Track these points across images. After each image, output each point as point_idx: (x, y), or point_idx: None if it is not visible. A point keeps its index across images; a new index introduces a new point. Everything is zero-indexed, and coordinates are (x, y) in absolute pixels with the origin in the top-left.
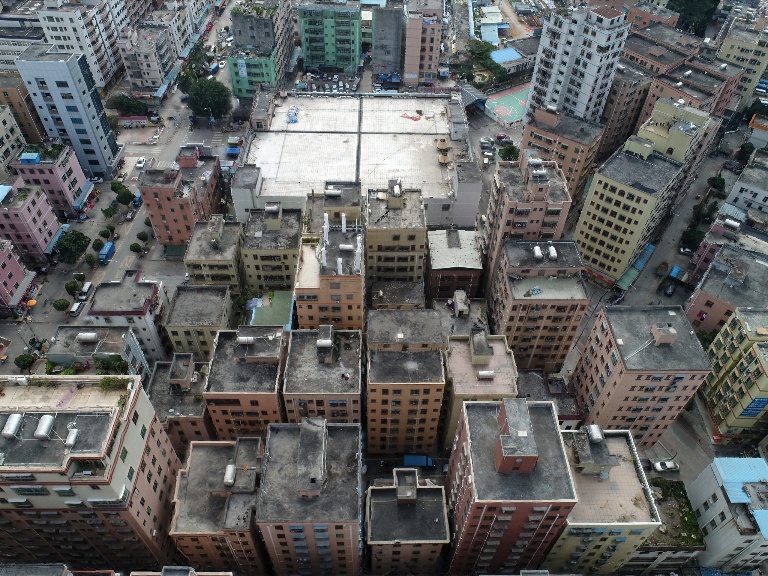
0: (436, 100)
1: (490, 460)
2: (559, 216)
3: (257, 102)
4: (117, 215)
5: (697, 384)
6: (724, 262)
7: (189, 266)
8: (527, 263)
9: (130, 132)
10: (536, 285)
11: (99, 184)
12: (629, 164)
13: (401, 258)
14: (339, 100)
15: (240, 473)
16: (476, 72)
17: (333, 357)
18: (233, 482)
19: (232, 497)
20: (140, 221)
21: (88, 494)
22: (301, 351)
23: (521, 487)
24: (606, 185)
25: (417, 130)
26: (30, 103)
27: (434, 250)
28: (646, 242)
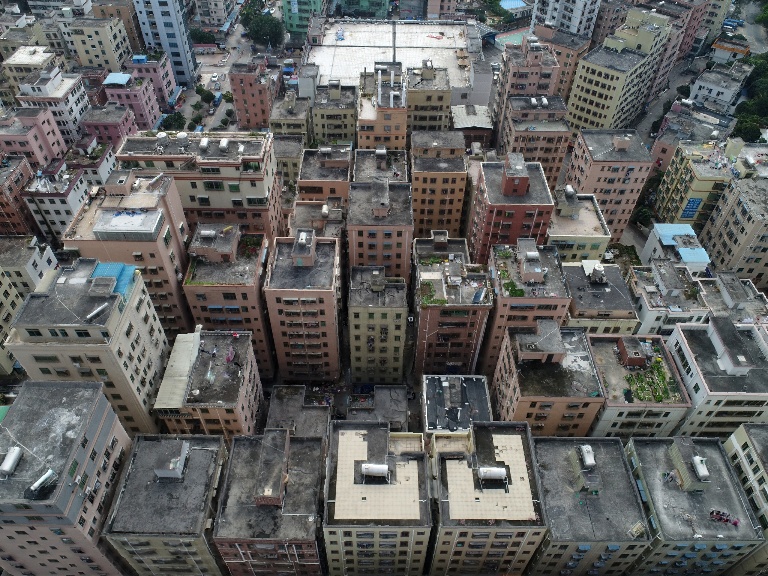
0: (455, 26)
1: (498, 190)
2: (550, 79)
3: (312, 24)
4: (201, 111)
5: (644, 176)
6: (677, 122)
7: (272, 125)
8: (526, 109)
9: (203, 57)
10: (532, 125)
11: (184, 91)
12: (606, 55)
13: (432, 117)
14: (376, 25)
15: (331, 212)
16: (487, 17)
17: (386, 165)
18: (328, 213)
19: (327, 225)
20: (220, 115)
21: (248, 191)
22: (363, 162)
23: (518, 201)
24: (588, 69)
25: (440, 45)
26: (135, 21)
27: (456, 117)
28: (622, 126)
